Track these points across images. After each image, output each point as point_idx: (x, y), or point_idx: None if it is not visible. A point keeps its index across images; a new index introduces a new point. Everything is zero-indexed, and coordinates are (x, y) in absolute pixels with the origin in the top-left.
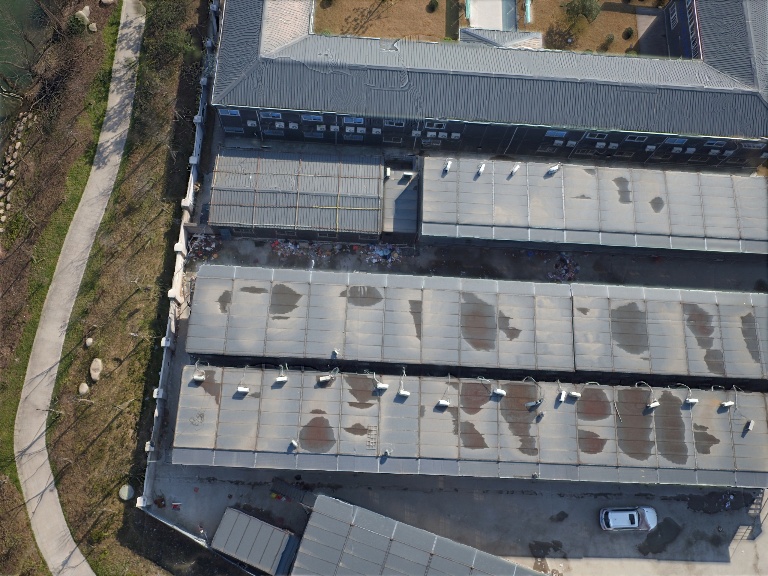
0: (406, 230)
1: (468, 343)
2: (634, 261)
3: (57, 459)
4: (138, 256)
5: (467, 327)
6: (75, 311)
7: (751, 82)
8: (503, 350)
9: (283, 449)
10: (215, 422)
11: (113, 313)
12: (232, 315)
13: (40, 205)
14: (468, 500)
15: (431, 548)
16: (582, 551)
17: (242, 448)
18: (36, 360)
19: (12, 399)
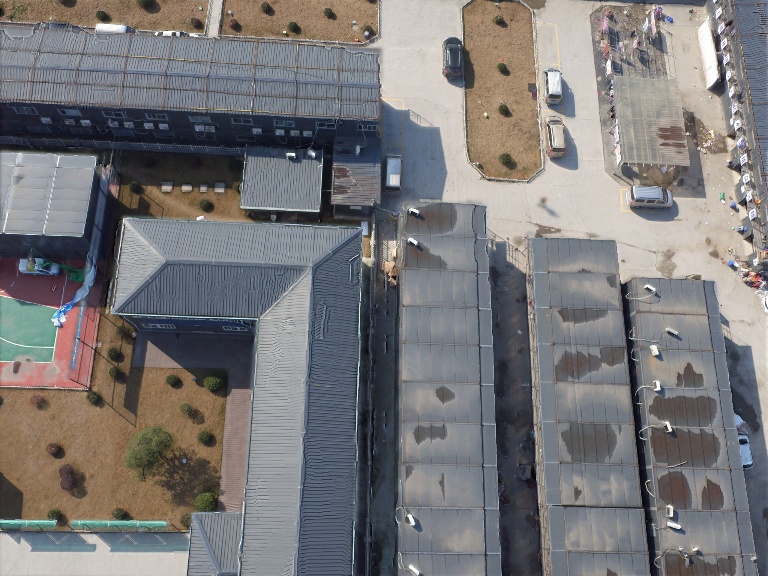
0: None
1: None
2: None
3: None
4: None
5: None
6: None
7: (297, 272)
8: None
9: None
10: None
11: None
12: None
13: None
14: None
15: None
16: (767, 488)
17: None
18: None
19: None
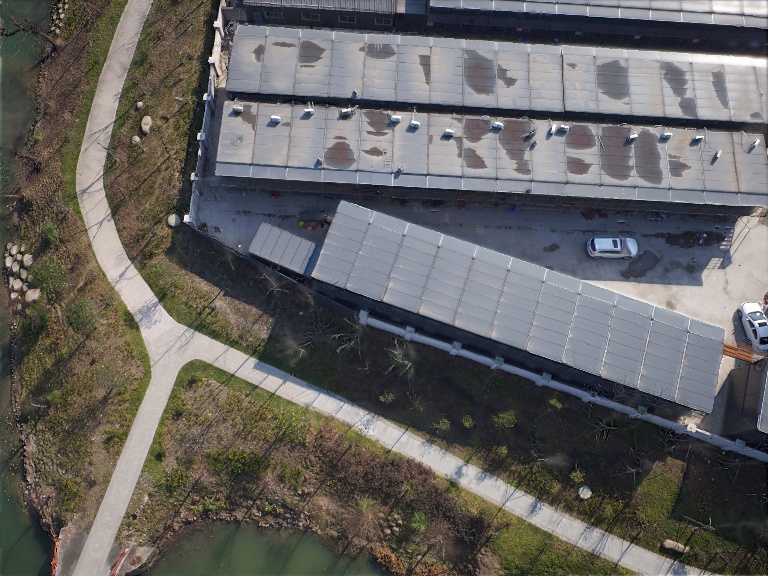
0: (416, 12)
1: (471, 89)
2: (620, 48)
3: (113, 196)
4: (181, 38)
5: (470, 76)
6: (127, 83)
7: None
8: (501, 94)
9: (310, 165)
10: (252, 144)
11: (160, 82)
12: (266, 63)
13: (95, 1)
14: (471, 233)
15: (438, 243)
16: (571, 275)
17: (275, 163)
18: (94, 121)
19: (74, 150)
